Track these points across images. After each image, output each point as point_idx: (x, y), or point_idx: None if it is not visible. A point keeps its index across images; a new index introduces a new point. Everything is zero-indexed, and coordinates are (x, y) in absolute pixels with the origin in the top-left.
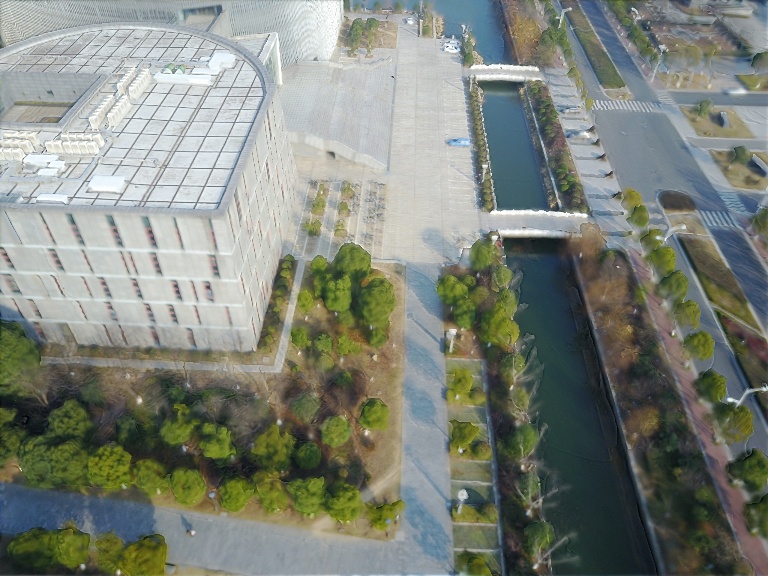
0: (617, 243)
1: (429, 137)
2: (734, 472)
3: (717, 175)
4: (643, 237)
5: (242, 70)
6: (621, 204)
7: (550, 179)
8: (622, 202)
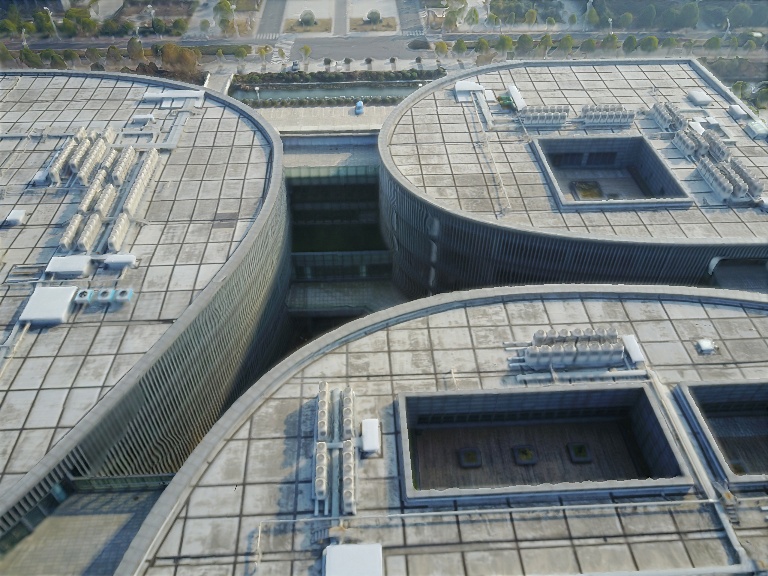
0: (471, 65)
1: (349, 123)
2: (631, 51)
3: (382, 33)
4: (477, 50)
5: (478, 81)
6: (443, 53)
7: (398, 82)
8: (442, 52)
